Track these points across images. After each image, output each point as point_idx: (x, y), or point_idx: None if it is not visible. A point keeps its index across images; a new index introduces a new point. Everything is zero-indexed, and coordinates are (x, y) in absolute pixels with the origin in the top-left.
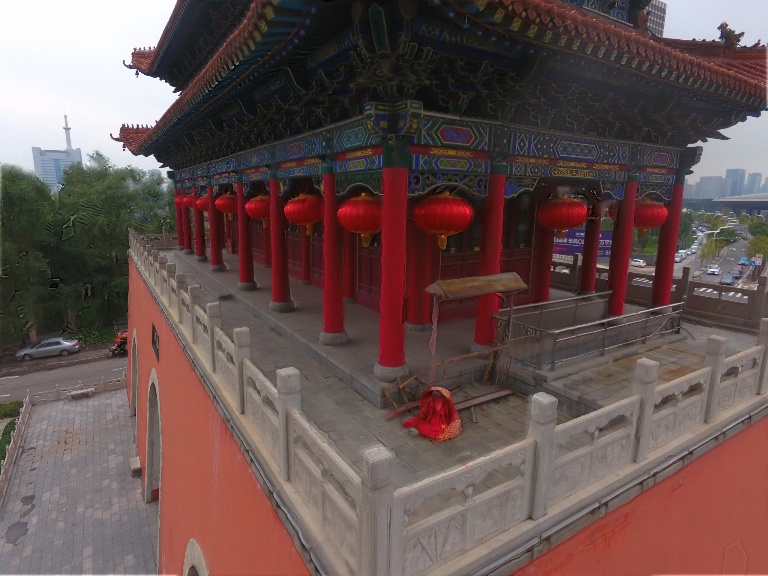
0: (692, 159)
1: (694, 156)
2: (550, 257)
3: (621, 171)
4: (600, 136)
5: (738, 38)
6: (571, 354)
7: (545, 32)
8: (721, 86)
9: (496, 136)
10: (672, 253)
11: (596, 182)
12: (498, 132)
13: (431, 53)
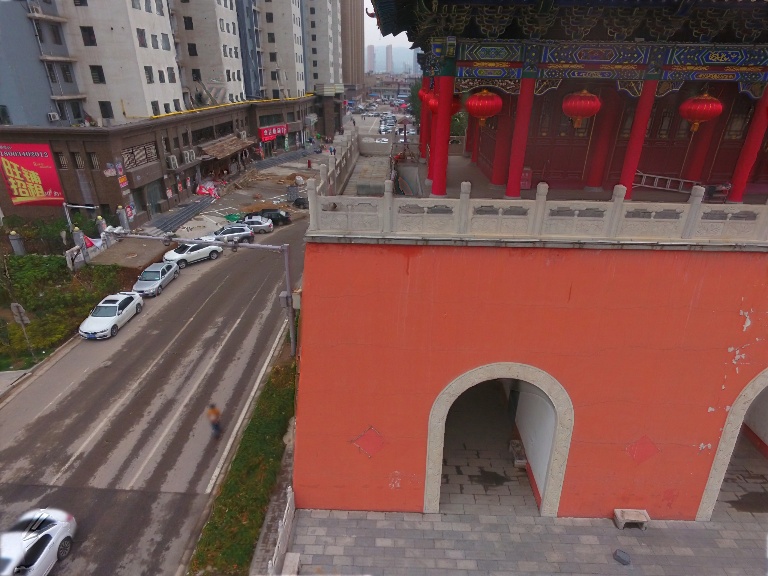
0: None
1: None
2: (496, 144)
3: None
4: None
5: None
6: None
7: None
8: None
9: None
10: None
11: None
12: None
13: (412, 38)
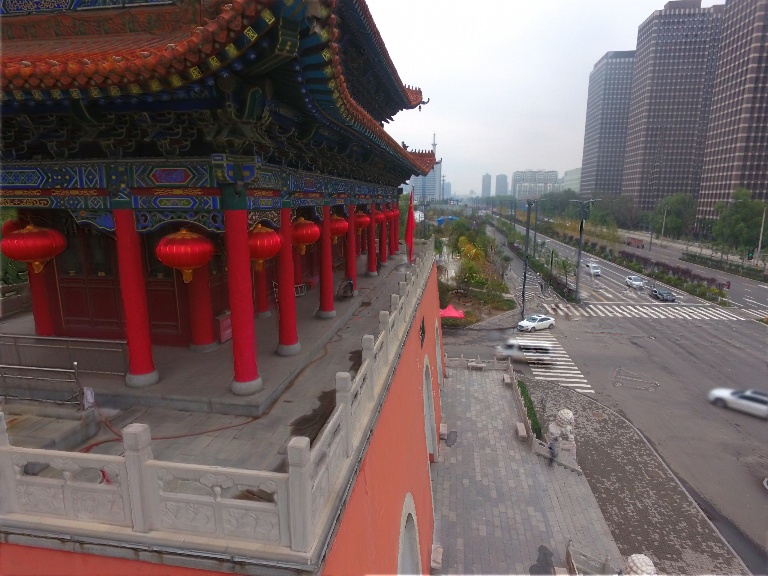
0: None
1: None
2: (195, 292)
3: (98, 196)
4: (44, 159)
5: None
6: (39, 397)
7: None
8: None
9: None
10: (233, 308)
11: (63, 210)
12: None
13: None
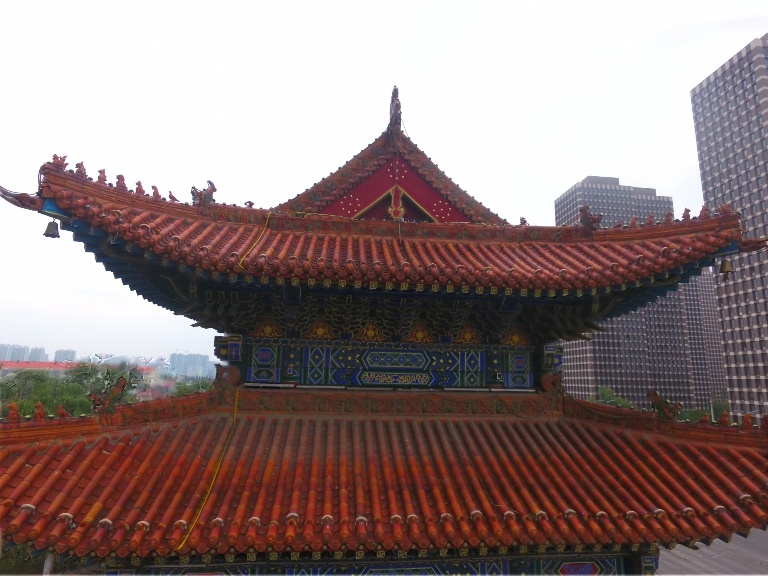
0: (639, 573)
1: (640, 569)
2: None
3: None
4: None
5: (674, 411)
6: None
7: (154, 558)
8: (522, 545)
9: (262, 575)
10: None
11: None
12: (264, 571)
13: None
